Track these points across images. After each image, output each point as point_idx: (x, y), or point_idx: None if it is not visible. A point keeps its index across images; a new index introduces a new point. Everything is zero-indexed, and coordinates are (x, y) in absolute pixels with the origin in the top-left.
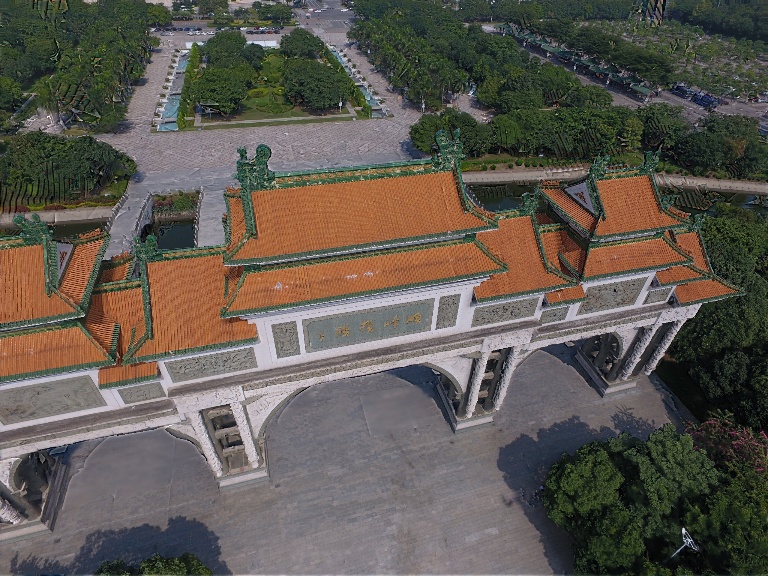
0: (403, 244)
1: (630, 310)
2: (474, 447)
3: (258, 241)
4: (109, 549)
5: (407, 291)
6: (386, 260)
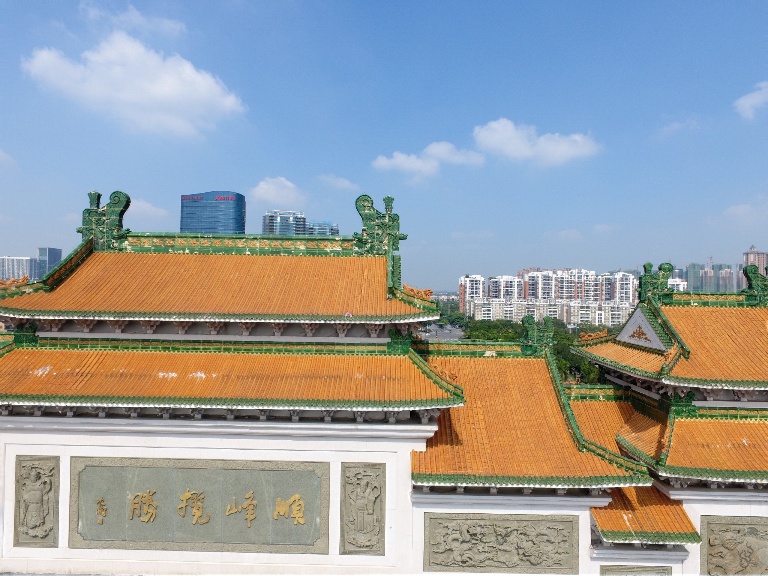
0: (276, 338)
1: None
2: None
3: (48, 296)
4: None
5: (263, 424)
6: (240, 361)
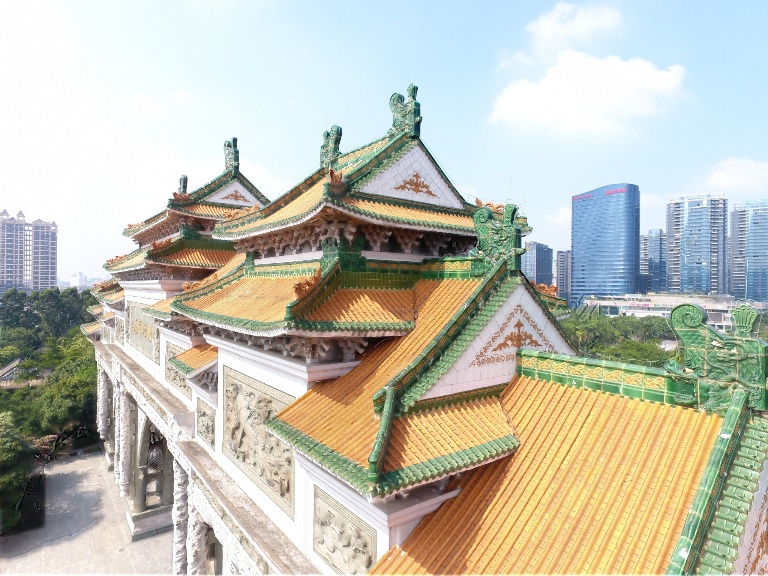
0: None
1: (289, 540)
2: None
3: None
4: (84, 494)
5: None
6: None
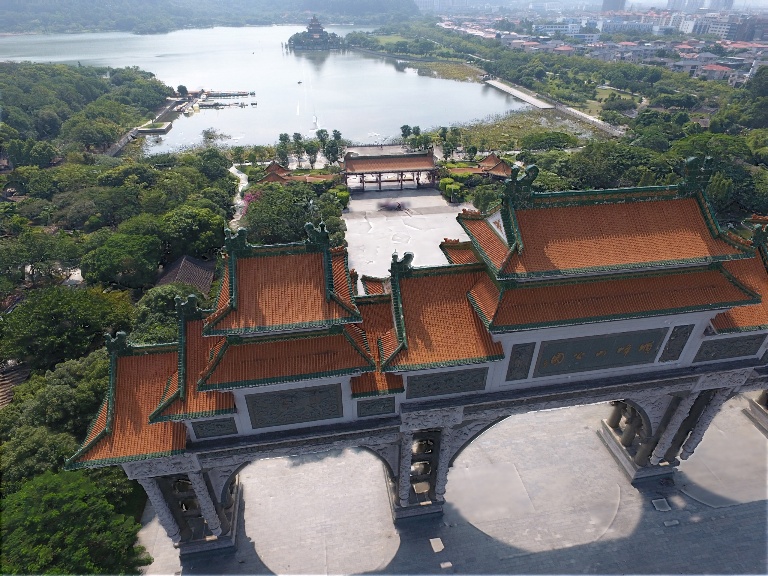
0: None
1: None
2: None
3: None
4: None
5: None
6: None
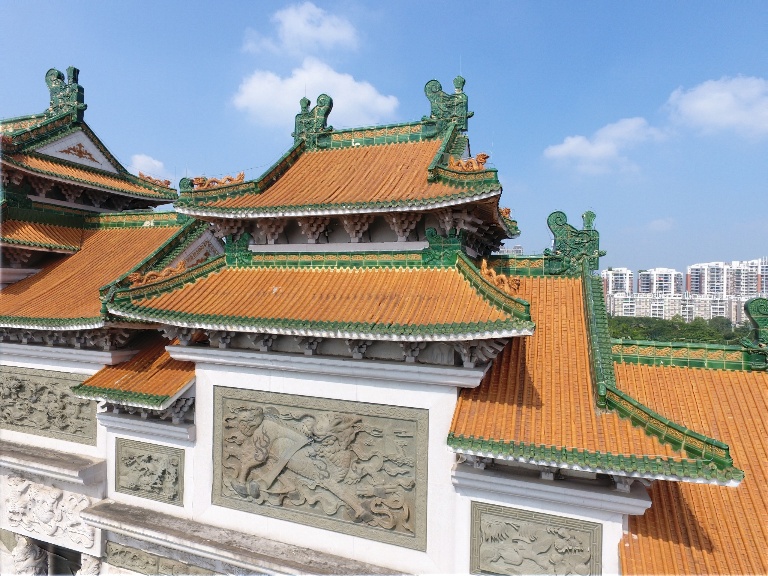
0: None
1: (416, 575)
2: None
3: None
4: None
5: None
6: None
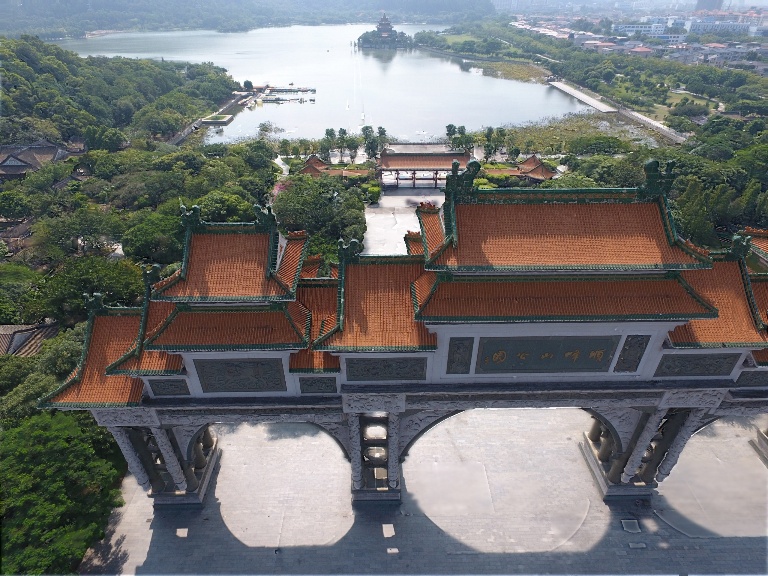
0: None
1: None
2: (385, 434)
3: None
4: None
5: None
6: None
